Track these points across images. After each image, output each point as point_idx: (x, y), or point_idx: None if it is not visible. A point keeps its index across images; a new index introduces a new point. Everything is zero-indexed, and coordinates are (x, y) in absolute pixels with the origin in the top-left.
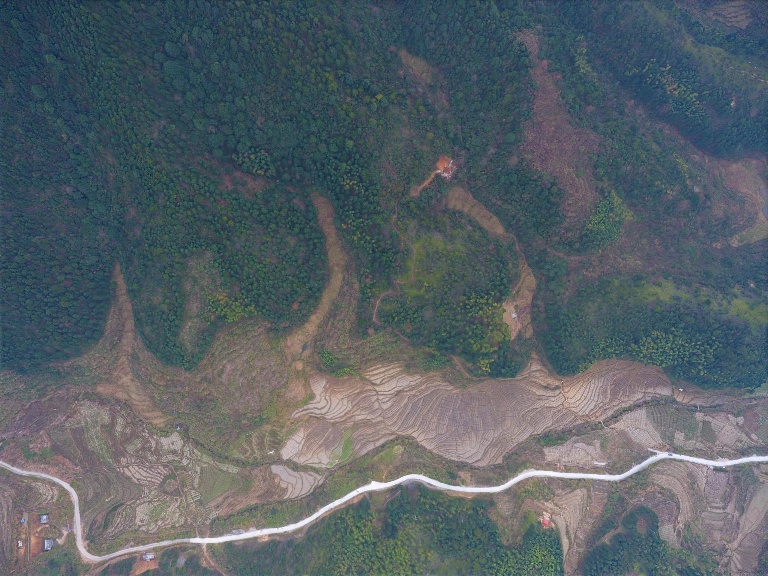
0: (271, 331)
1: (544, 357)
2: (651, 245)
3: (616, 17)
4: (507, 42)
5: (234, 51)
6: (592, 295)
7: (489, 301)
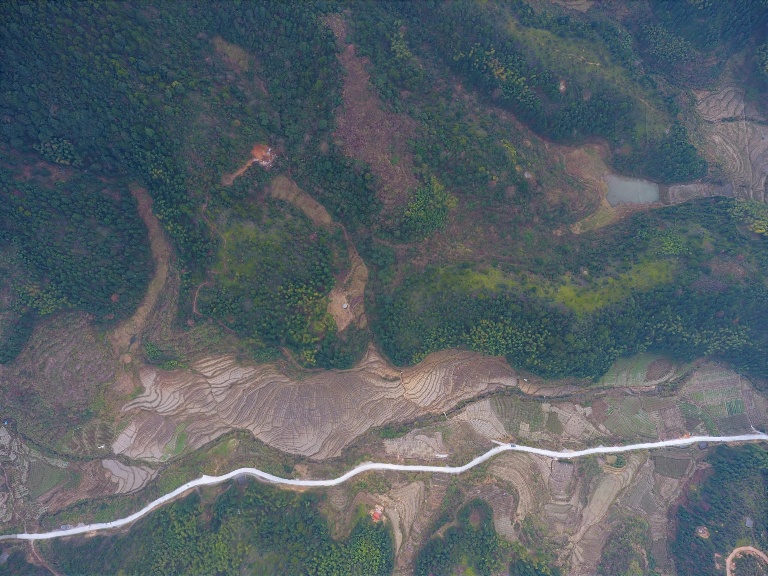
0: (95, 324)
1: (380, 348)
2: (486, 233)
3: (436, 1)
4: (313, 27)
5: (8, 38)
6: (417, 284)
7: (308, 291)
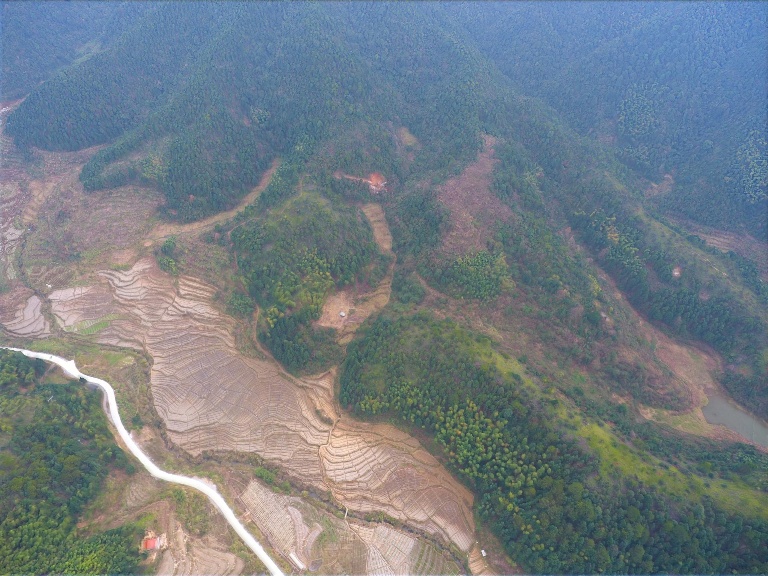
0: None
1: None
2: (530, 343)
3: (580, 174)
4: (473, 134)
5: None
6: (425, 323)
7: None
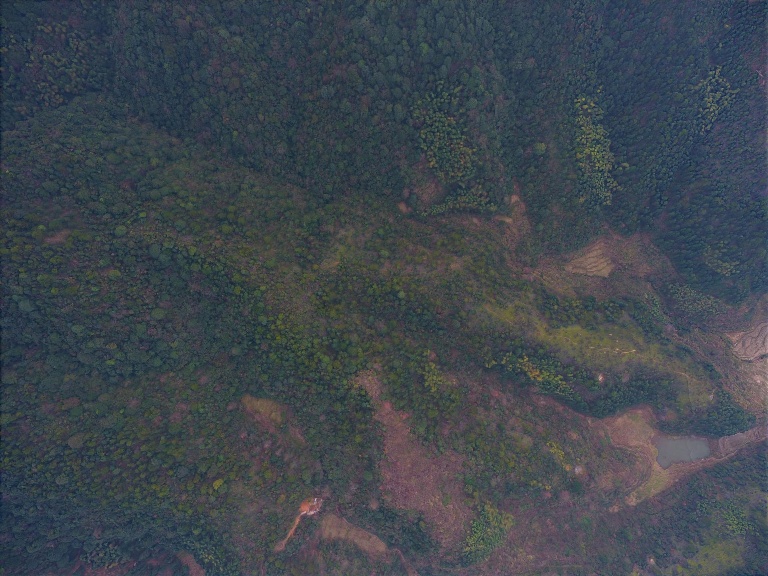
0: None
1: None
2: (543, 528)
3: (462, 321)
4: (345, 390)
5: None
6: None
7: None
